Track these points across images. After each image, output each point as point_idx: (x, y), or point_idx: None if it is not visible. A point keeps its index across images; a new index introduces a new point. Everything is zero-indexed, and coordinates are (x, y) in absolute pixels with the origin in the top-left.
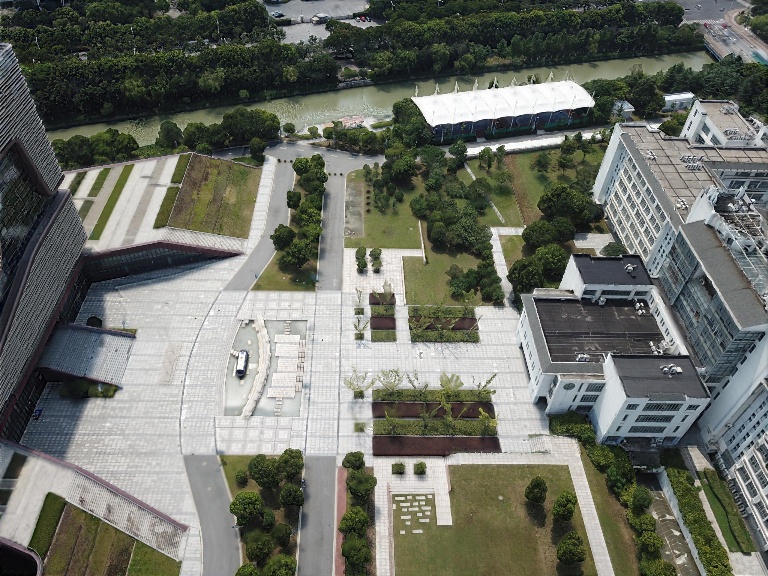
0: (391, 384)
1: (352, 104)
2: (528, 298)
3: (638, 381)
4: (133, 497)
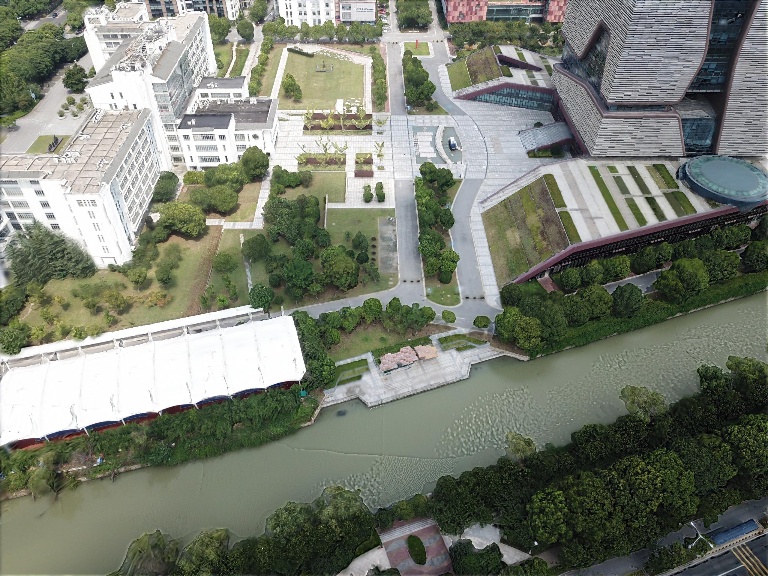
0: None
1: None
2: (269, 124)
3: (234, 83)
4: (480, 90)
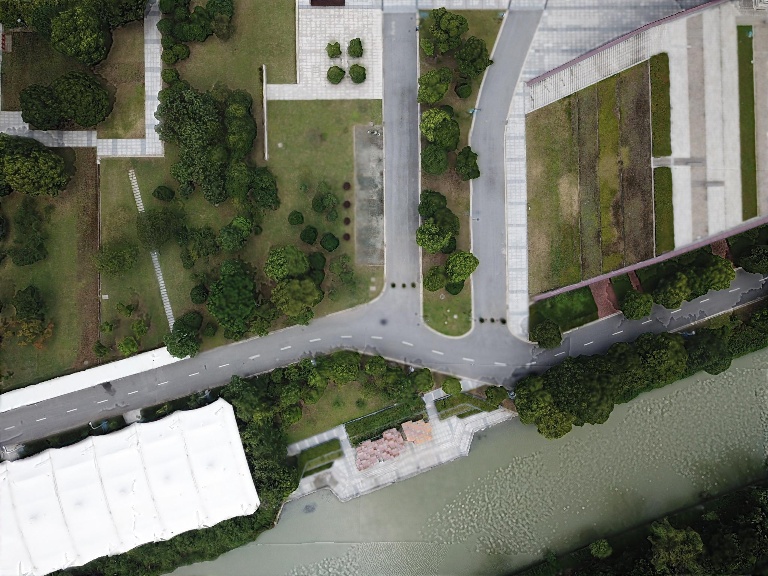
0: None
1: None
2: None
3: None
4: None
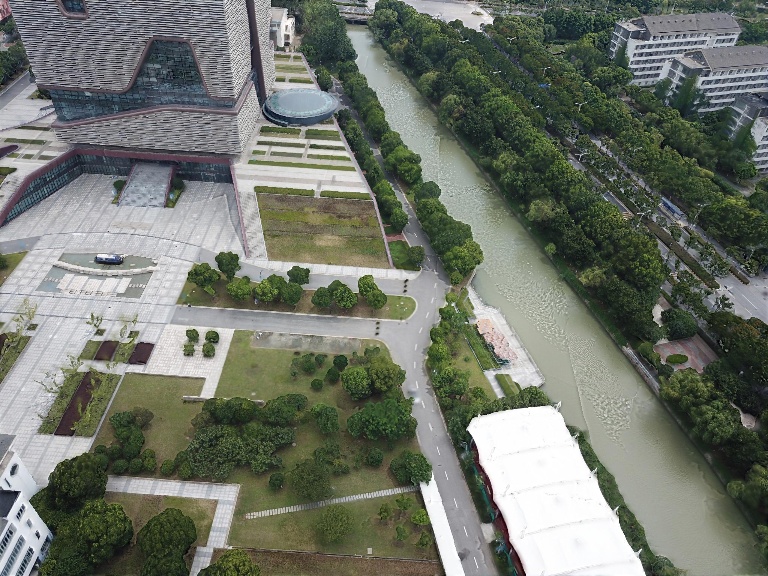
0: (12, 336)
1: (619, 383)
2: (1, 437)
3: None
4: (7, 207)
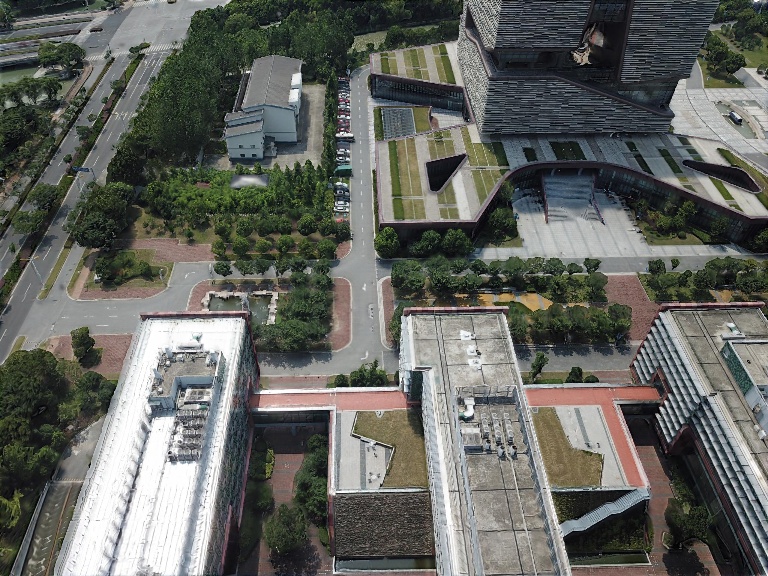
0: None
1: None
2: None
3: None
4: None
